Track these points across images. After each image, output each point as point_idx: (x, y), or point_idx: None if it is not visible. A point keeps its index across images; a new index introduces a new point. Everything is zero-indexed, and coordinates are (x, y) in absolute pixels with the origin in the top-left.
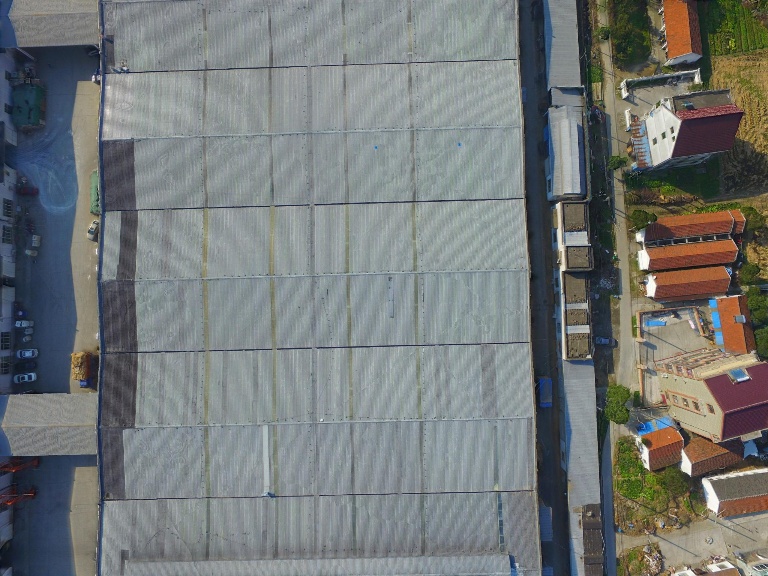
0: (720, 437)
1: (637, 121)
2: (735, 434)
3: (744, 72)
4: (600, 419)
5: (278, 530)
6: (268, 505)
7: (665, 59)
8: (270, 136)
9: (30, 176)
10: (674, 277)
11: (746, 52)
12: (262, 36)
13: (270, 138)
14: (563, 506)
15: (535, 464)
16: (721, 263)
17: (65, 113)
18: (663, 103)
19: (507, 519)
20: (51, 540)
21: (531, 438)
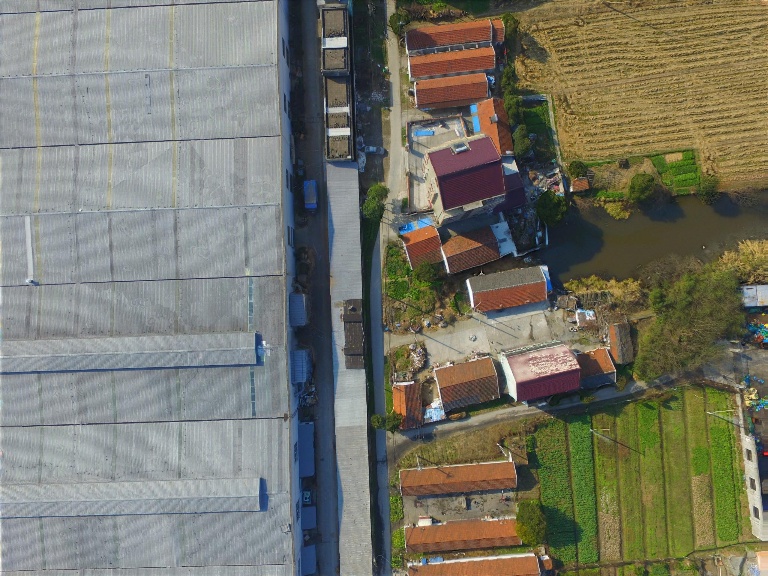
0: None
1: None
2: (456, 203)
3: None
4: (361, 218)
5: (40, 315)
6: (32, 293)
7: None
8: None
9: None
10: (435, 83)
11: None
12: None
13: None
14: None
15: (283, 249)
16: (482, 70)
17: None
18: None
19: (257, 302)
20: None
21: (279, 224)
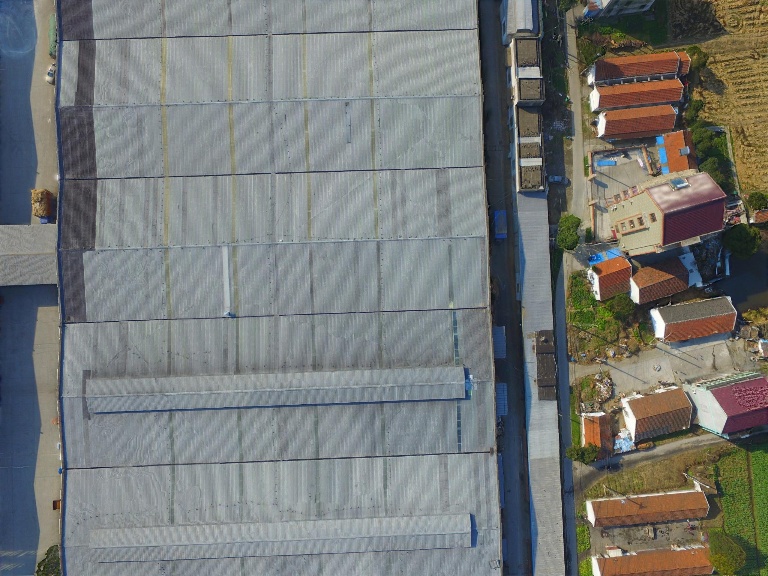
0: (661, 242)
1: None
2: (675, 239)
3: None
4: (552, 248)
5: (239, 348)
6: (229, 325)
7: None
8: None
9: None
10: (623, 114)
11: None
12: None
13: None
14: (518, 336)
15: (488, 281)
16: (668, 101)
17: None
18: None
19: (462, 335)
20: (14, 379)
21: (484, 256)
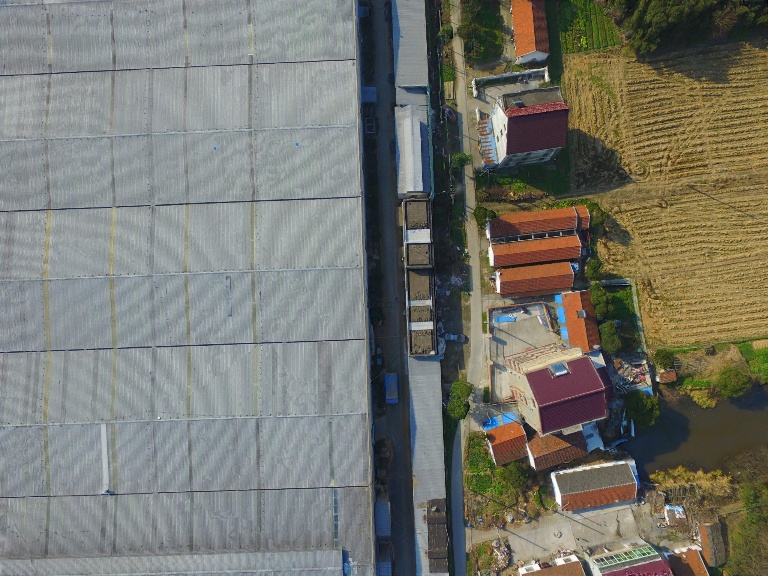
0: (541, 431)
1: None
2: (555, 428)
3: (595, 69)
4: (444, 415)
5: (116, 527)
6: (107, 503)
7: (516, 57)
8: (111, 138)
9: None
10: (519, 273)
11: (597, 50)
12: (105, 39)
13: (111, 140)
14: (412, 501)
15: (369, 460)
16: (566, 259)
17: None
18: (498, 101)
19: (342, 514)
20: None
21: (365, 434)
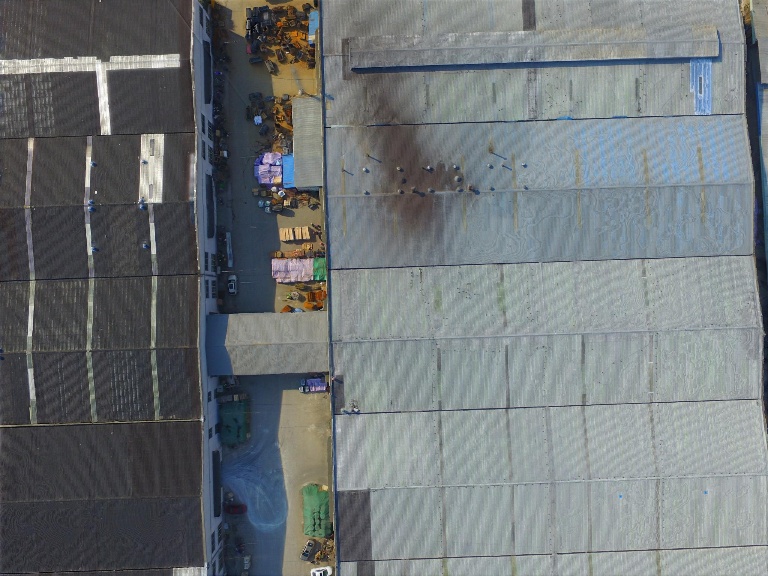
0: None
1: None
2: None
3: None
4: None
5: None
6: None
7: None
8: (512, 485)
9: (236, 491)
10: None
11: None
12: (499, 376)
13: (512, 487)
14: None
15: None
16: None
17: (271, 424)
18: None
19: None
20: None
21: None
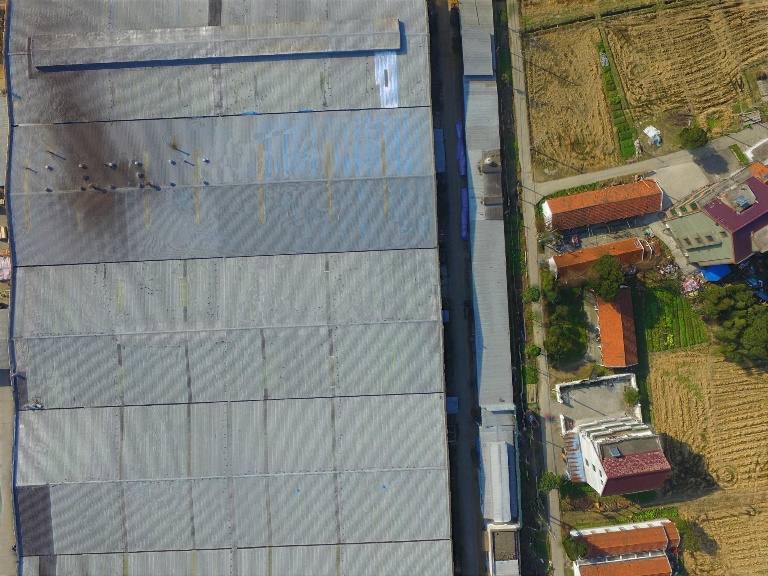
0: None
1: (572, 429)
2: None
3: (682, 369)
4: None
5: None
6: None
7: (601, 360)
8: (189, 480)
9: None
10: None
11: (684, 348)
12: (180, 371)
13: (189, 482)
14: None
15: None
16: None
17: None
18: (592, 441)
19: None
20: None
21: None
